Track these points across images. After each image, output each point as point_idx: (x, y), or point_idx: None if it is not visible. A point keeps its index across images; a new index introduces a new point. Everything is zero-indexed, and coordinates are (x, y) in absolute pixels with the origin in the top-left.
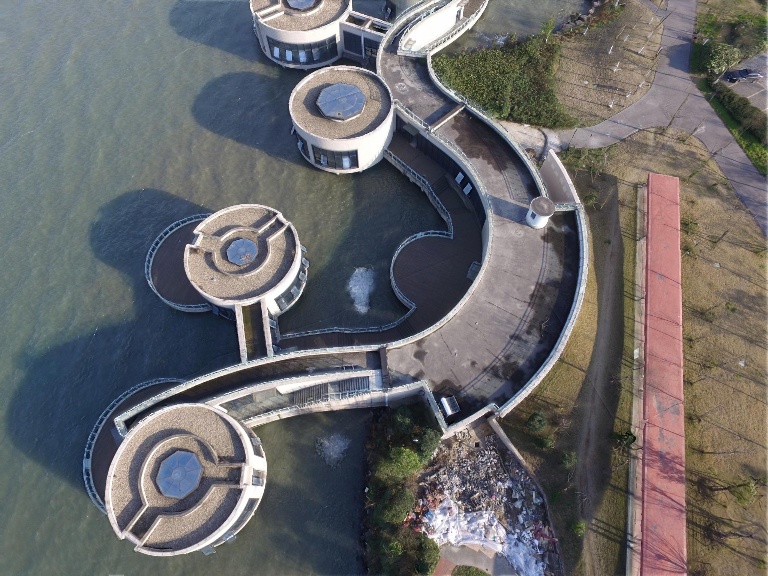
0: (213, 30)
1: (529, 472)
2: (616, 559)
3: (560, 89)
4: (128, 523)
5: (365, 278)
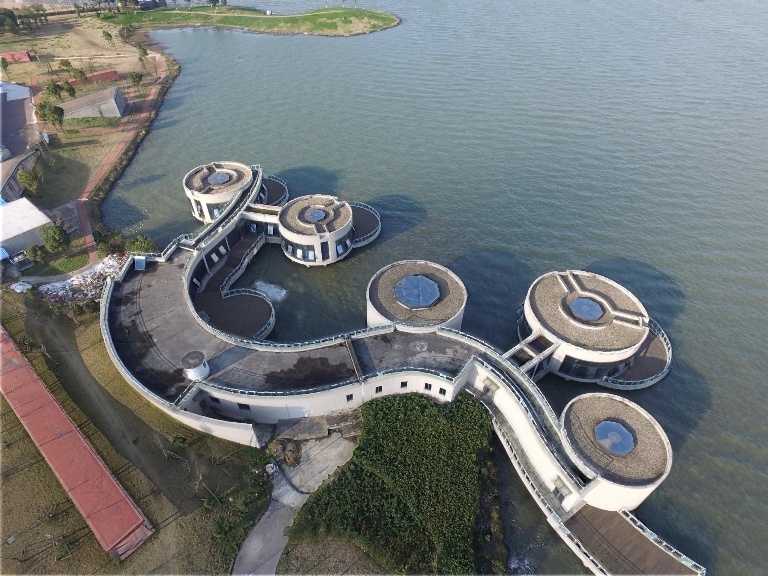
0: None
1: (80, 302)
2: (2, 314)
3: (364, 568)
4: None
5: (275, 292)
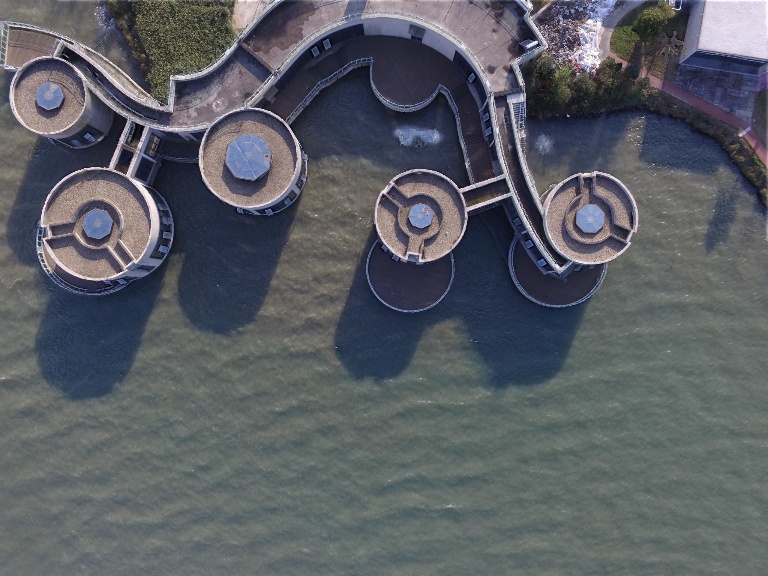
0: (118, 338)
1: (555, 1)
2: None
3: None
4: (621, 243)
5: (410, 135)
